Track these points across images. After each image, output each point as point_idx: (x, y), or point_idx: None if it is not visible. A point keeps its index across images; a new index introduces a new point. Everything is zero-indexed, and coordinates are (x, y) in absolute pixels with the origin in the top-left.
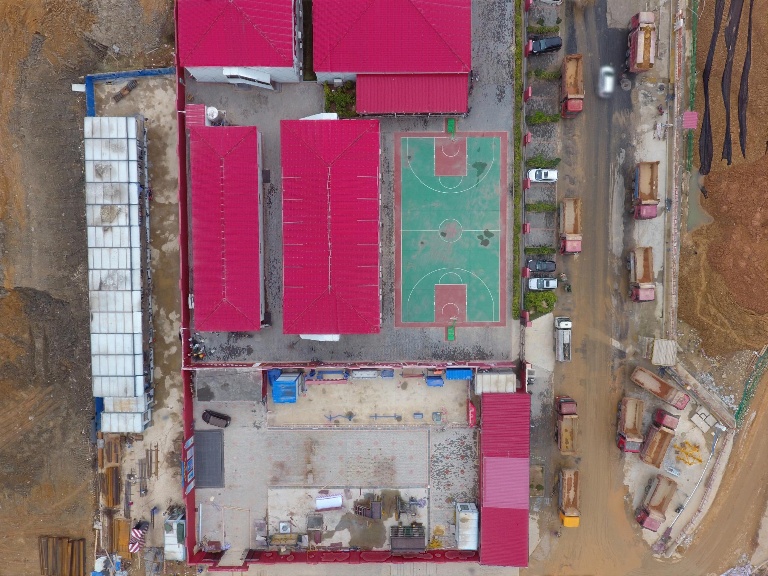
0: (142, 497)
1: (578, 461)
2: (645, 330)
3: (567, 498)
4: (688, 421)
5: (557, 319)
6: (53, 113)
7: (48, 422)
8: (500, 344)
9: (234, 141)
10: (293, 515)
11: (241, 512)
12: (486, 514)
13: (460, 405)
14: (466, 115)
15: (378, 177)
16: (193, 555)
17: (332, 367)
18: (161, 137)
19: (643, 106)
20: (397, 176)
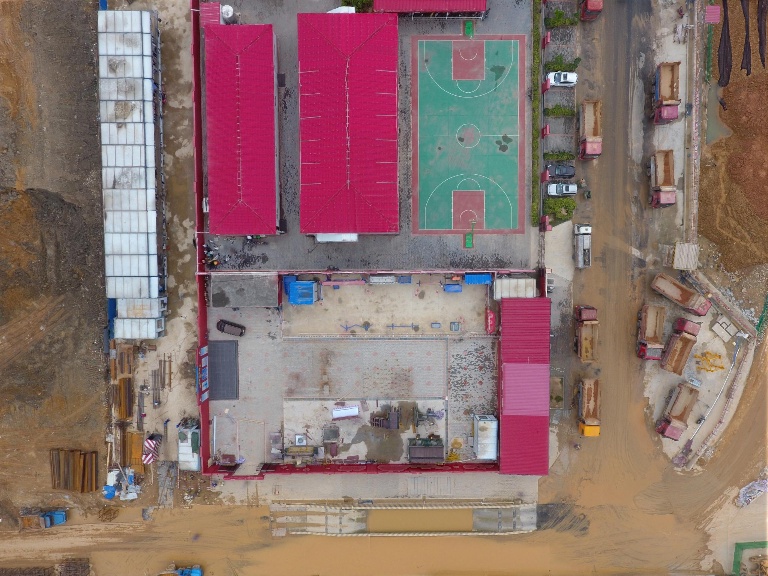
0: (155, 409)
1: (598, 372)
2: (665, 238)
3: (587, 409)
4: (709, 331)
5: (577, 225)
6: (65, 13)
7: (60, 332)
8: (519, 252)
9: (250, 39)
10: (309, 428)
11: (256, 425)
12: (505, 422)
13: (478, 315)
14: (484, 17)
15: (397, 72)
16: (207, 467)
17: (349, 272)
18: (175, 40)
19: (663, 9)
20: (414, 80)
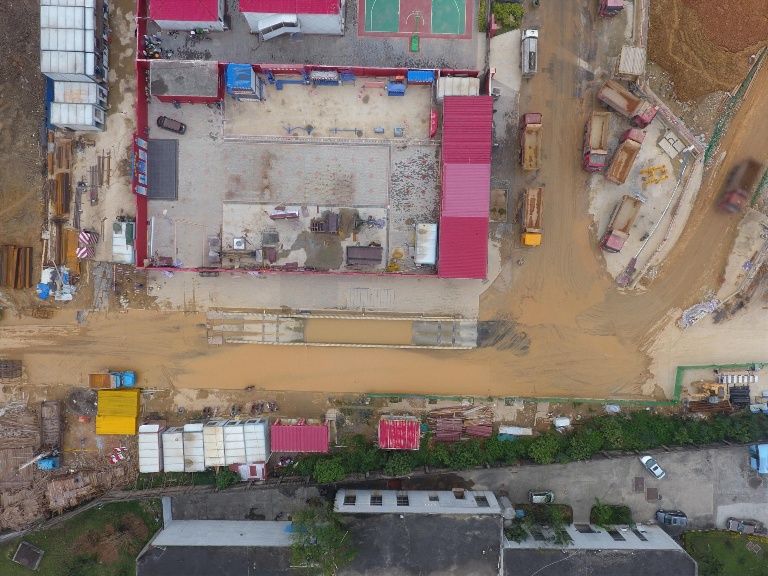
0: (92, 206)
1: None
2: (614, 51)
3: (530, 220)
4: (656, 147)
5: (524, 29)
6: None
7: None
8: (465, 58)
9: None
10: (248, 232)
11: (194, 227)
12: (445, 224)
13: (423, 122)
14: None
15: None
16: (143, 266)
17: None
18: None
19: None
20: None
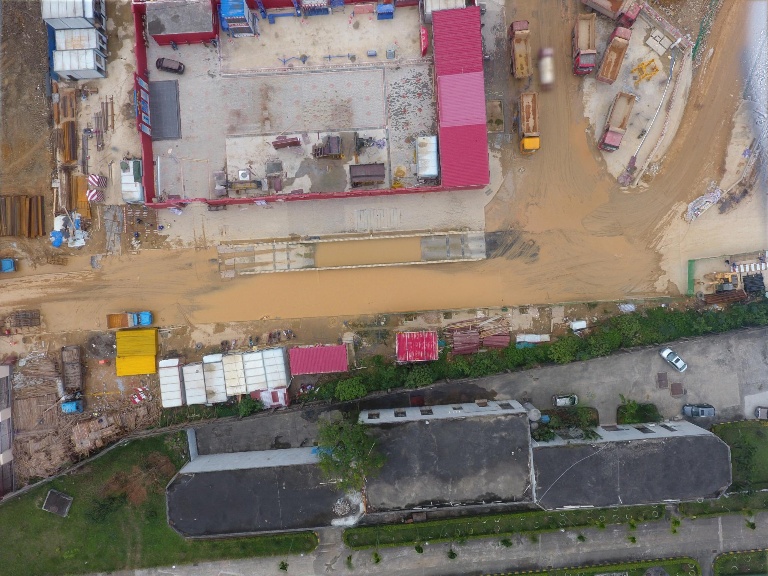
0: (99, 151)
1: None
2: None
3: (527, 127)
4: (643, 46)
5: None
6: None
7: (3, 79)
8: None
9: None
10: (252, 163)
11: (199, 163)
12: (444, 135)
13: (413, 42)
14: None
15: None
16: None
17: None
18: None
19: None
20: None
